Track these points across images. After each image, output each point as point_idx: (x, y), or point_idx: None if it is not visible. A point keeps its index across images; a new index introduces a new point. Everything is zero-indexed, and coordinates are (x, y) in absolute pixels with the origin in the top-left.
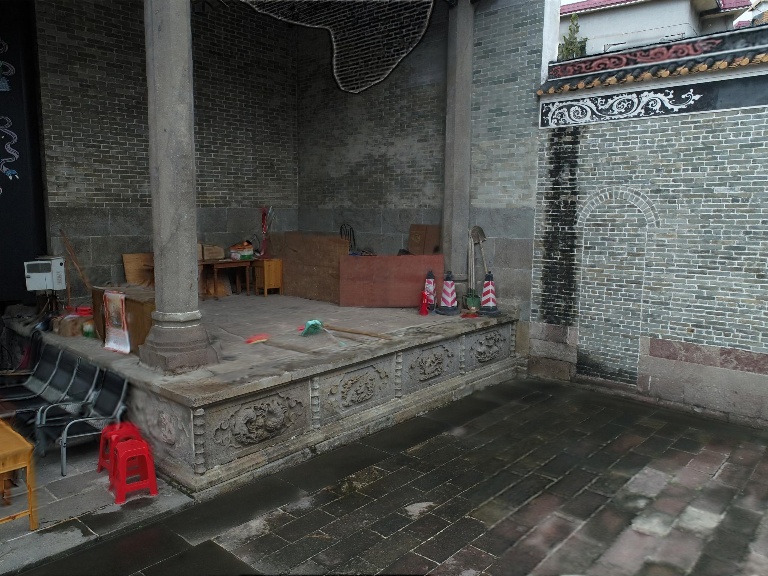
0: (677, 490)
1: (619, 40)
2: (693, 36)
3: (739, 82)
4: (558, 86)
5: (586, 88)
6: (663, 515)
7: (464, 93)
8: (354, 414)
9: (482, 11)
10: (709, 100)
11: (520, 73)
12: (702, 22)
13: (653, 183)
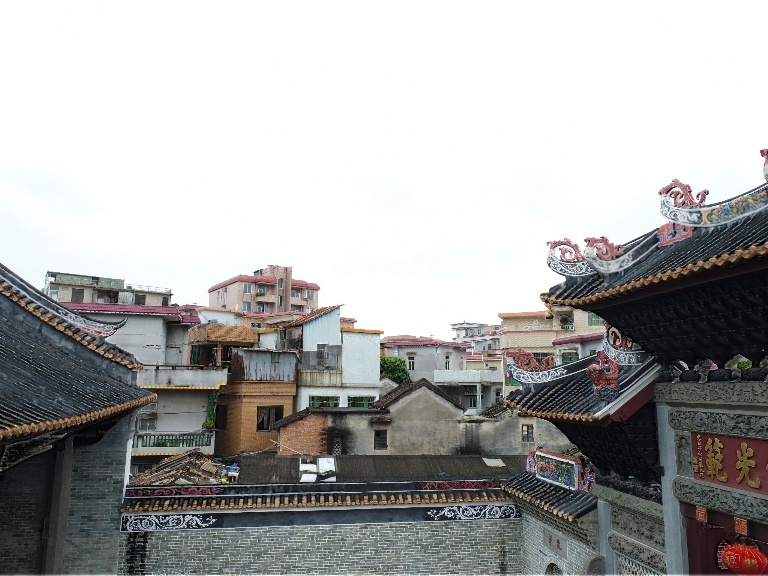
0: None
1: (109, 338)
2: (163, 340)
3: (233, 515)
4: (134, 505)
5: (153, 510)
6: None
7: (65, 508)
8: None
9: (80, 449)
10: (220, 522)
11: (107, 494)
12: (168, 326)
13: (192, 567)
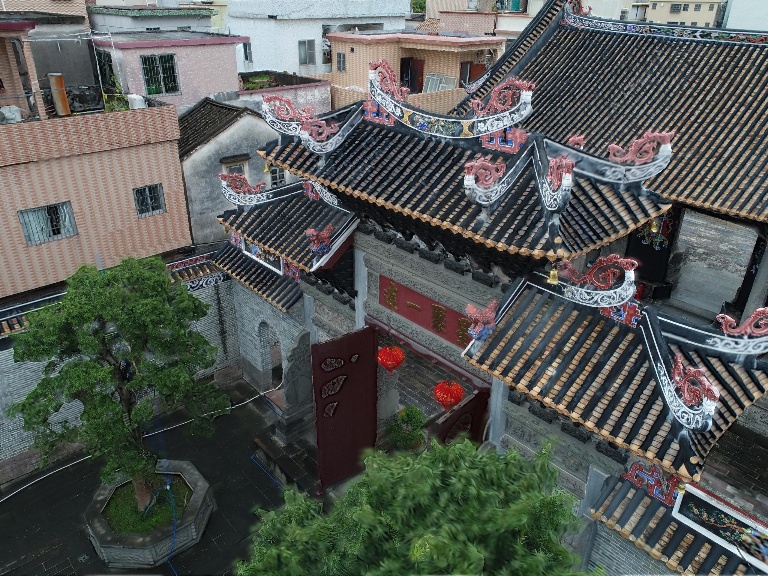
0: (767, 508)
1: None
2: None
3: None
4: None
5: None
6: (742, 496)
7: None
8: (764, 426)
9: None
10: None
11: None
12: None
13: None
